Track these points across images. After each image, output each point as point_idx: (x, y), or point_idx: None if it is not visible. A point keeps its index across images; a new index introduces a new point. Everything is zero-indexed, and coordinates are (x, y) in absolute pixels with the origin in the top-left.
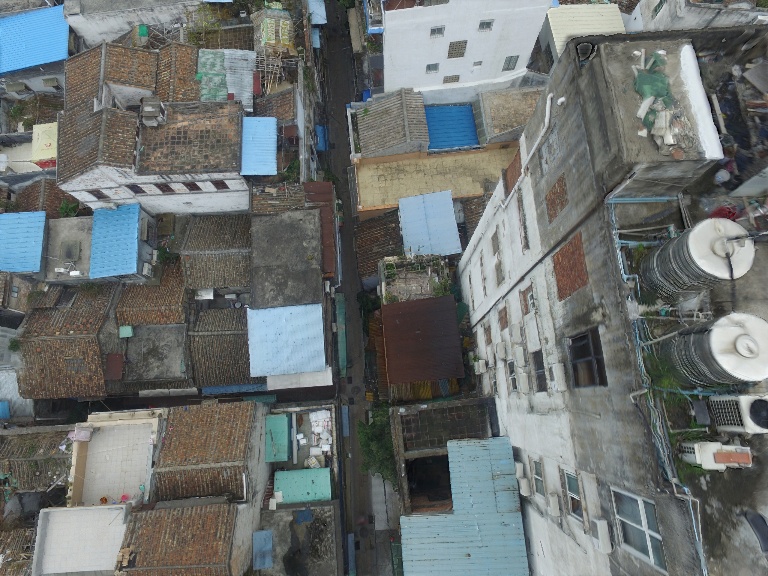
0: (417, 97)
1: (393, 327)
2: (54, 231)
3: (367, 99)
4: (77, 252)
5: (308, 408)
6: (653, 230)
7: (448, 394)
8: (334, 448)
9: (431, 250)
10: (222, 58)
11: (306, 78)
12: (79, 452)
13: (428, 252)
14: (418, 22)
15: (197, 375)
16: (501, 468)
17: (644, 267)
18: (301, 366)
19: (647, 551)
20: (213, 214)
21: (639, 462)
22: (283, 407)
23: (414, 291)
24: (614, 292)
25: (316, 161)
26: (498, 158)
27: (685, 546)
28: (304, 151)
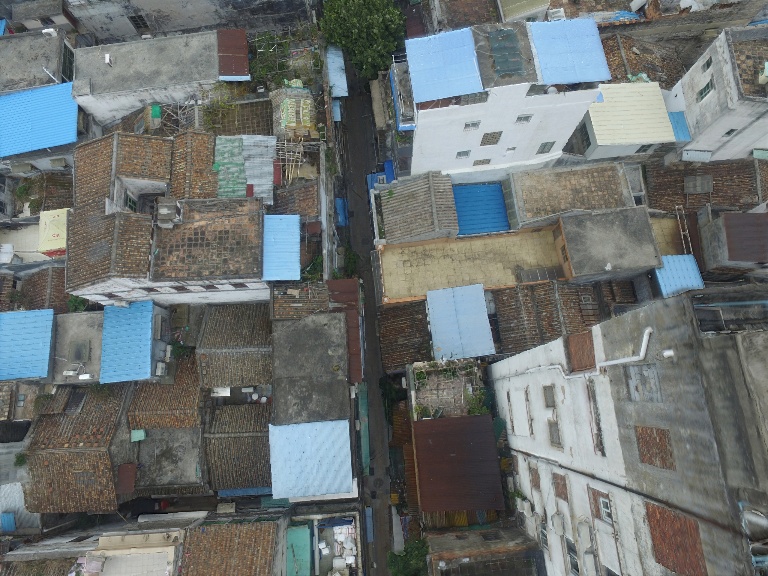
0: (445, 180)
1: (426, 447)
2: (62, 328)
3: (392, 181)
4: (87, 353)
5: (331, 516)
6: None
7: (485, 522)
8: (359, 561)
9: (462, 350)
10: (240, 145)
11: (328, 160)
12: None
13: (459, 352)
14: (452, 119)
15: (213, 478)
16: None
17: None
18: (327, 487)
19: None
20: (229, 303)
21: None
22: (304, 511)
23: None
24: None
25: (336, 240)
26: (530, 242)
27: None
28: (327, 242)
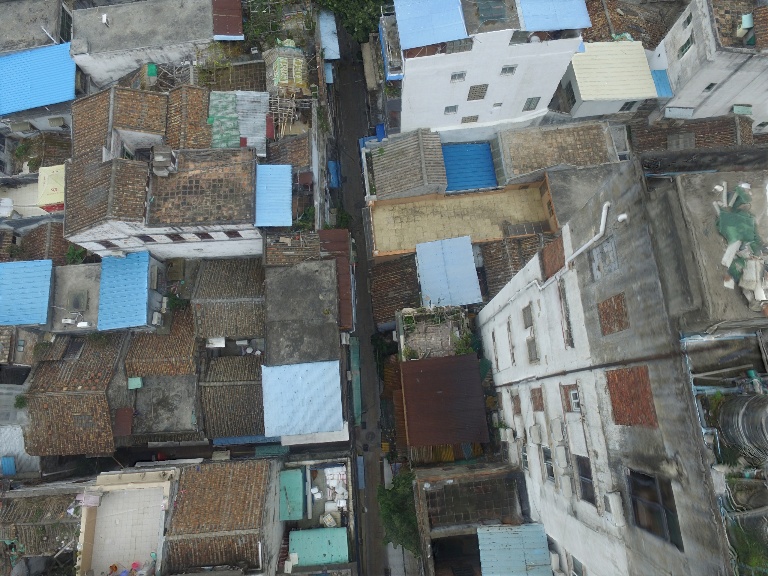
0: (434, 137)
1: (413, 386)
2: (61, 279)
3: None
4: (85, 302)
5: (323, 461)
6: (730, 372)
7: (471, 457)
8: (350, 504)
9: (450, 299)
10: (234, 101)
11: (320, 118)
12: (88, 517)
13: (447, 301)
14: (439, 68)
15: (208, 426)
16: (535, 558)
17: (724, 421)
18: (318, 426)
19: None
20: (224, 258)
21: None
22: (297, 458)
23: (433, 343)
24: (696, 457)
25: (329, 200)
26: (517, 199)
27: None
28: (318, 195)
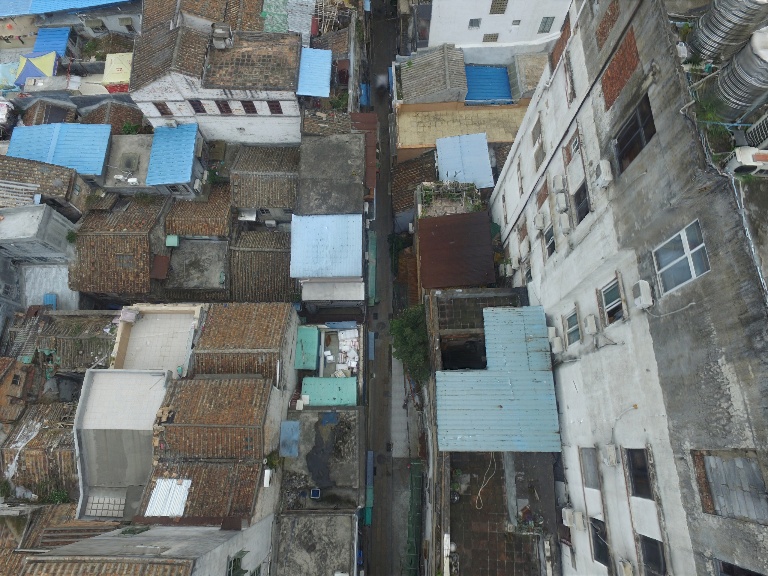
0: (458, 53)
1: (428, 238)
2: (116, 145)
3: (411, 53)
4: (136, 163)
5: None
6: None
7: None
8: (360, 364)
9: None
10: (285, 2)
11: (357, 29)
12: (123, 332)
13: None
14: None
15: (234, 289)
16: (534, 332)
17: (689, 36)
18: (339, 270)
19: (689, 272)
20: (261, 146)
21: (686, 166)
22: None
23: None
24: (665, 42)
25: (359, 110)
26: None
27: (728, 219)
28: (352, 89)
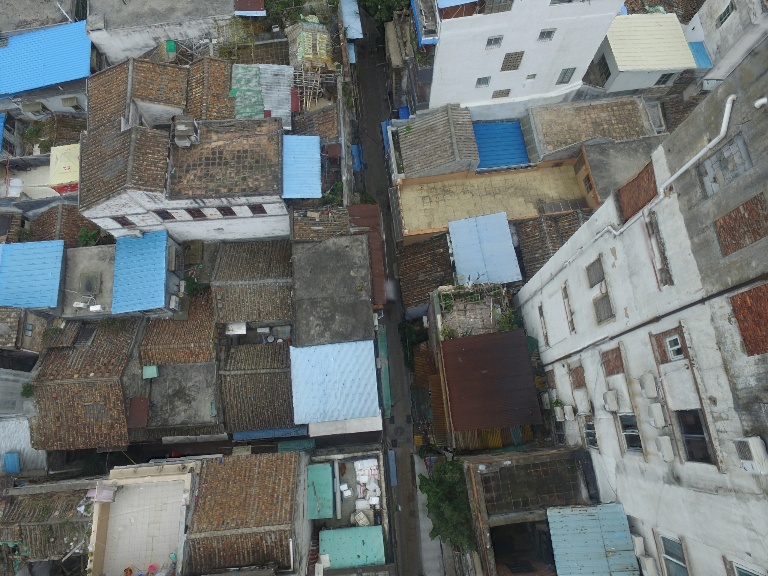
0: (464, 113)
1: (455, 366)
2: (72, 261)
3: (410, 116)
4: (98, 284)
5: (353, 455)
6: None
7: (520, 442)
8: (383, 501)
9: (487, 278)
10: (257, 73)
11: (345, 94)
12: (100, 515)
13: (484, 280)
14: (475, 32)
15: (228, 419)
16: (615, 543)
17: None
18: (351, 411)
19: None
20: (244, 240)
21: None
22: (323, 453)
23: (472, 323)
24: None
25: (353, 182)
26: (551, 177)
27: None
28: (345, 172)
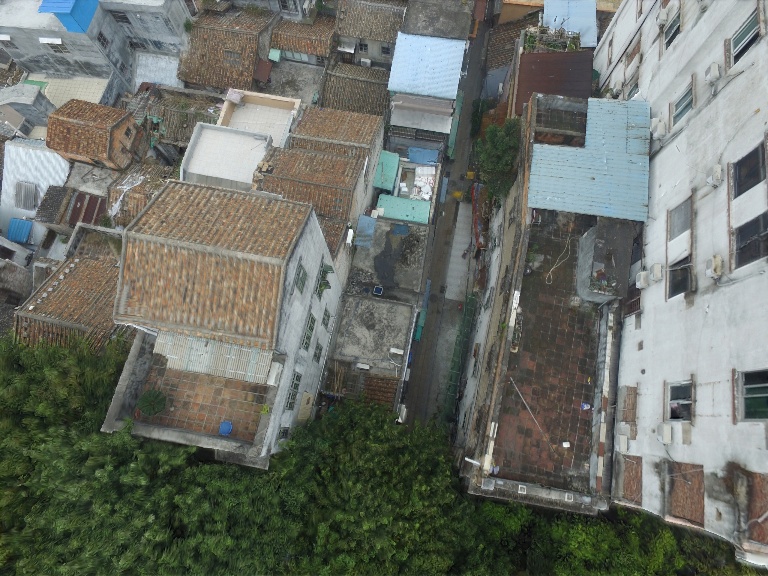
0: None
1: (528, 71)
2: None
3: None
4: None
5: (417, 161)
6: None
7: None
8: (433, 197)
9: None
10: None
11: None
12: (227, 111)
13: None
14: None
15: None
16: (636, 122)
17: None
18: (435, 91)
19: None
20: None
21: None
22: None
23: None
24: None
25: None
26: None
27: None
28: None
